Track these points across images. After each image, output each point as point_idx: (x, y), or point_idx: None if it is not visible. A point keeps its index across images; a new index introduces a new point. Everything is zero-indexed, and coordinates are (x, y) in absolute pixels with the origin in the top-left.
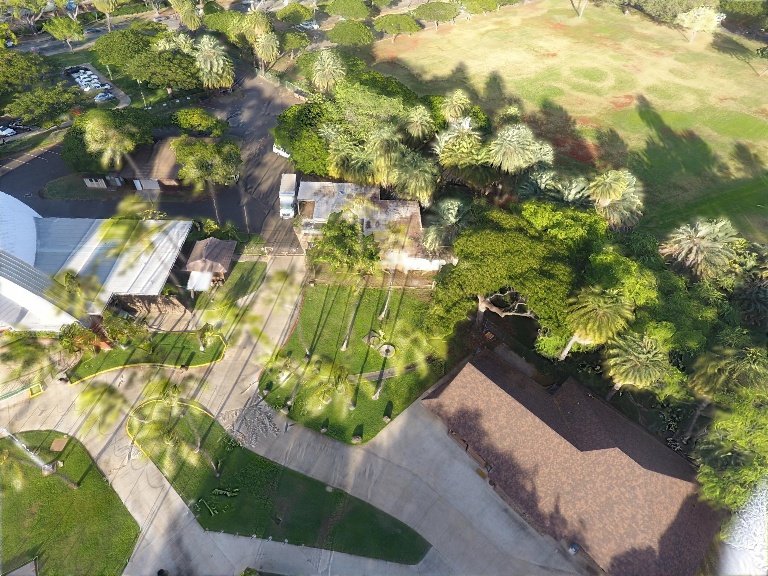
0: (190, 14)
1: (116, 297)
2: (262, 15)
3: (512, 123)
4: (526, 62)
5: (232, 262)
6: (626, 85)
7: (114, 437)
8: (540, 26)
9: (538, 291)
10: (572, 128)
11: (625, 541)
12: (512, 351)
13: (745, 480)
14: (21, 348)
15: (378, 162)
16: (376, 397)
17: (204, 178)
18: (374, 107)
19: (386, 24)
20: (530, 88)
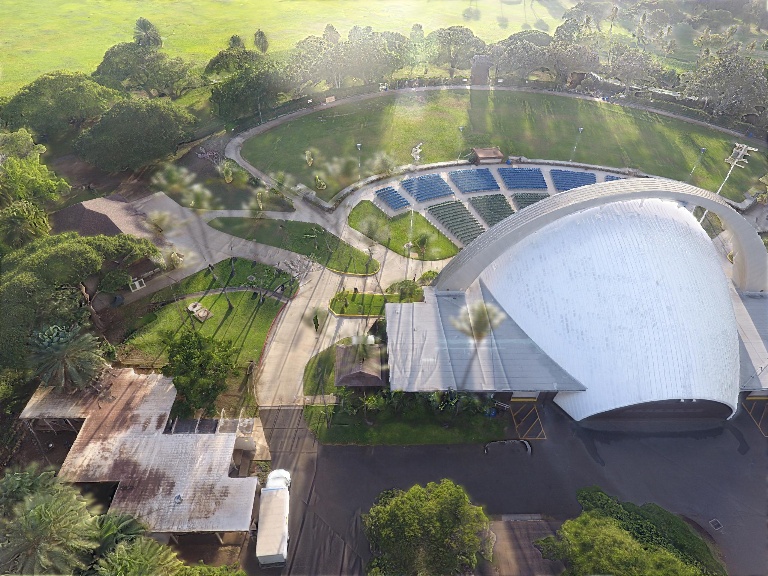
0: None
1: None
2: None
3: None
4: None
5: None
6: None
7: (384, 258)
8: None
9: None
10: None
11: None
12: None
13: None
14: None
15: None
16: None
17: None
18: None
19: None
20: None
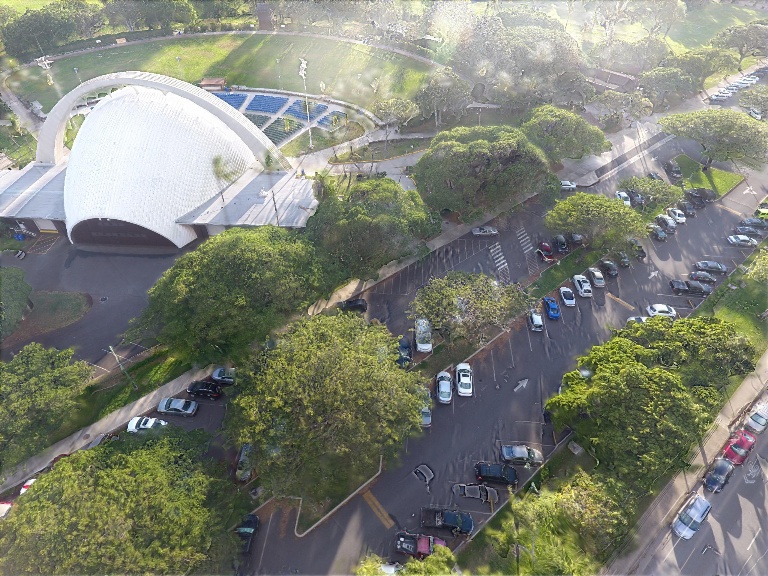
0: None
1: None
2: None
3: None
4: None
5: None
6: None
7: None
8: None
9: None
10: None
11: None
12: None
13: None
14: None
15: None
16: None
17: None
18: None
19: None
20: None
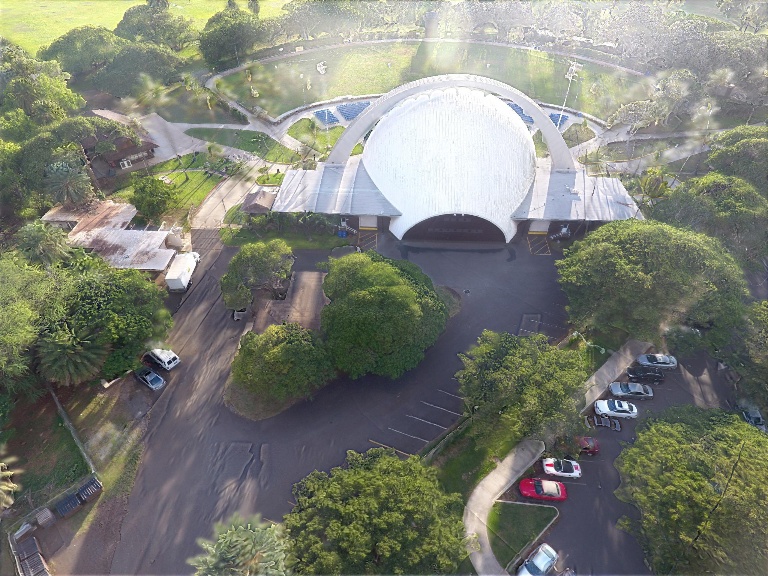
0: None
1: None
2: None
3: None
4: None
5: None
6: None
7: (307, 154)
8: None
9: None
10: None
11: None
12: None
13: None
14: None
15: None
16: None
17: None
18: None
19: None
20: None
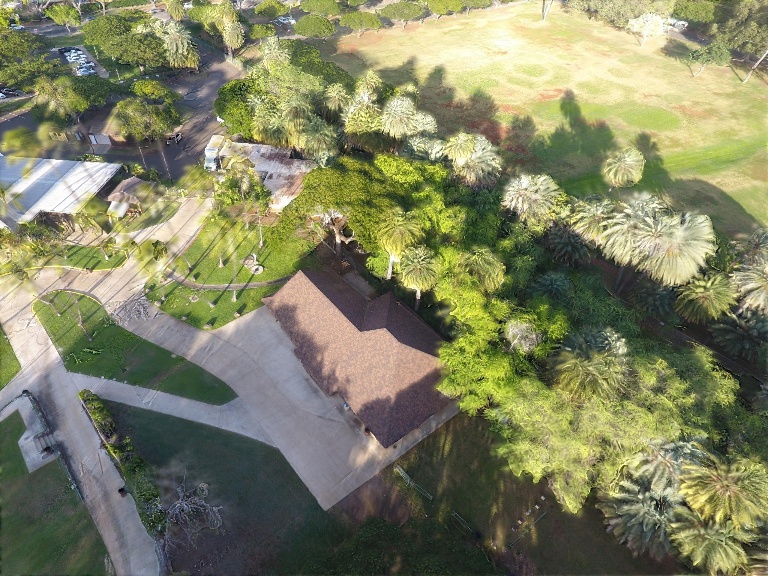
0: (175, 6)
1: (43, 213)
2: (229, 6)
3: (411, 99)
4: (475, 58)
5: (153, 200)
6: (560, 80)
7: (21, 312)
8: (503, 28)
9: (357, 214)
10: (492, 114)
11: (373, 393)
12: (360, 276)
13: (459, 346)
14: None
15: (290, 127)
16: (234, 299)
17: (143, 134)
18: (294, 81)
19: (350, 20)
20: (469, 79)
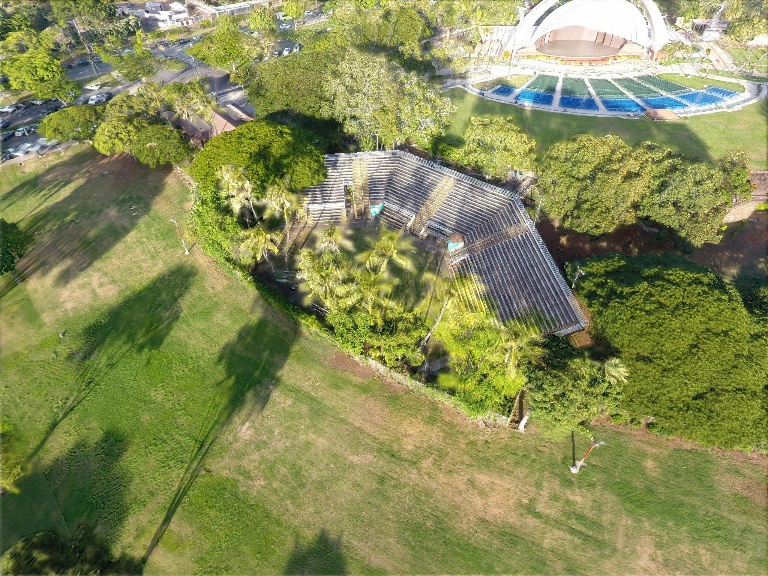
0: None
1: None
2: None
3: None
4: None
5: None
6: None
7: None
8: None
9: None
10: None
11: None
12: None
13: None
14: (631, 61)
15: (733, 6)
16: None
17: None
18: None
19: None
20: None
